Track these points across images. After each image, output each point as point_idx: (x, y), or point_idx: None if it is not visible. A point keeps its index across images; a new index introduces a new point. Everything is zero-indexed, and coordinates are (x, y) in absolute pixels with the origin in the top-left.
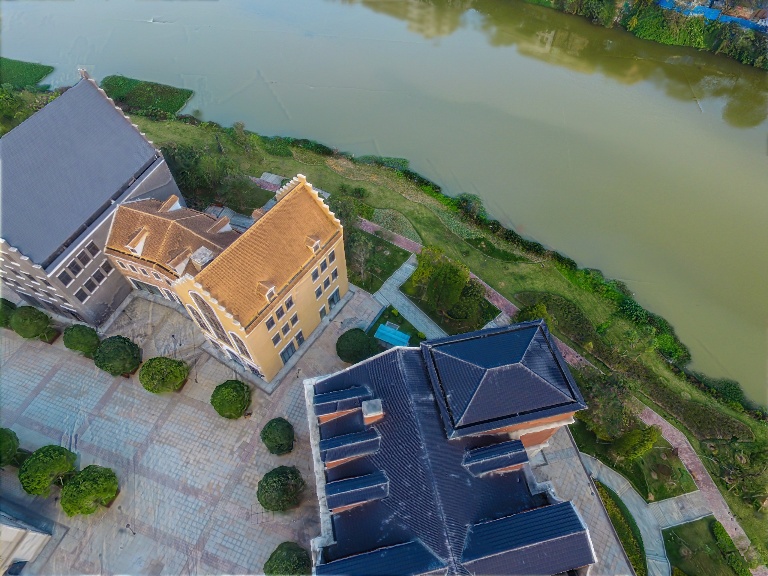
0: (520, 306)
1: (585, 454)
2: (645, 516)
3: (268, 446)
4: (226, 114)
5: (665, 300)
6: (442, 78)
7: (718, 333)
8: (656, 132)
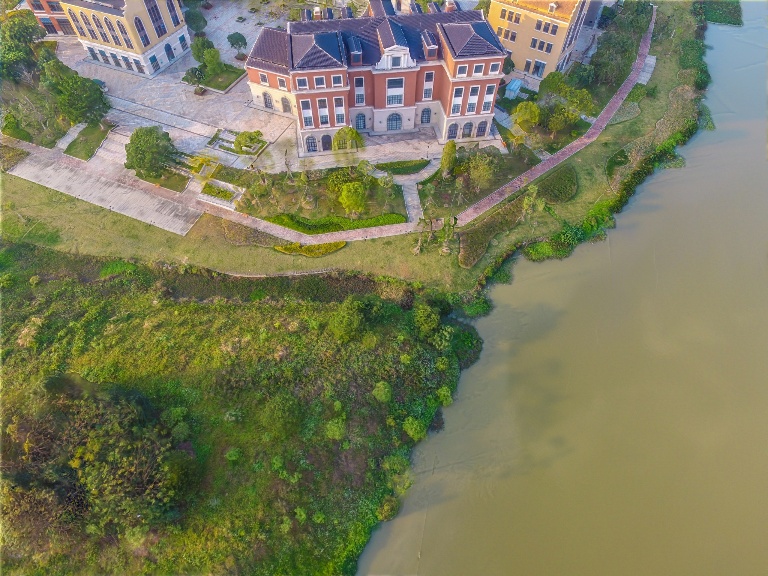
0: (559, 165)
1: None
2: (409, 181)
3: None
4: (721, 41)
5: (592, 264)
6: None
7: (561, 291)
8: None
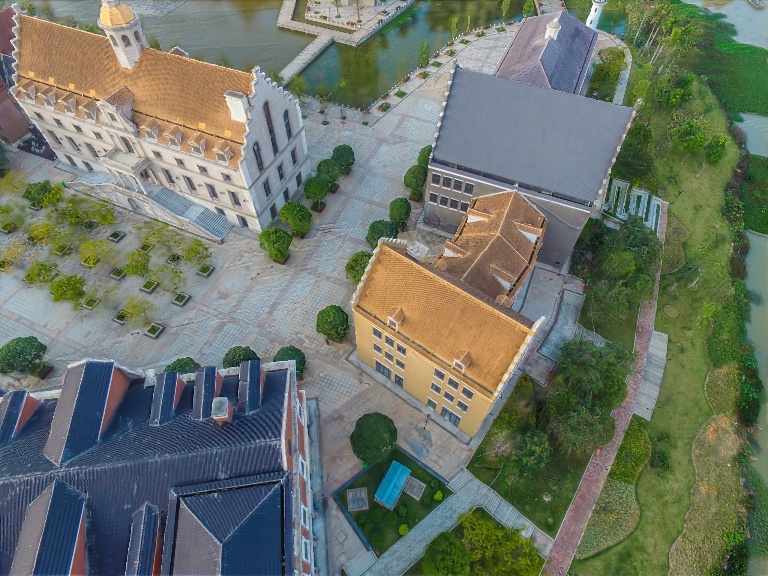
0: None
1: None
2: None
3: None
4: None
5: None
6: None
7: None
8: None
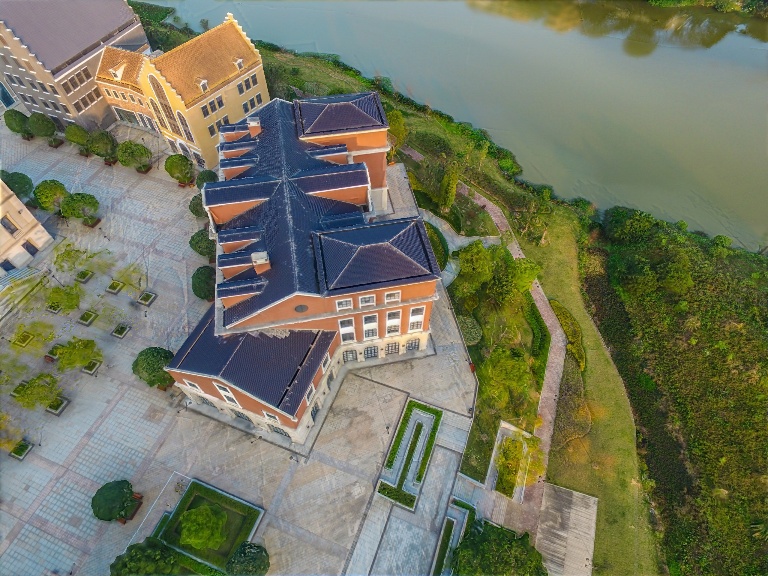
0: None
1: (422, 209)
2: (455, 241)
3: (200, 186)
4: (199, 24)
5: (514, 141)
6: (378, 3)
7: (548, 160)
8: (542, 40)
